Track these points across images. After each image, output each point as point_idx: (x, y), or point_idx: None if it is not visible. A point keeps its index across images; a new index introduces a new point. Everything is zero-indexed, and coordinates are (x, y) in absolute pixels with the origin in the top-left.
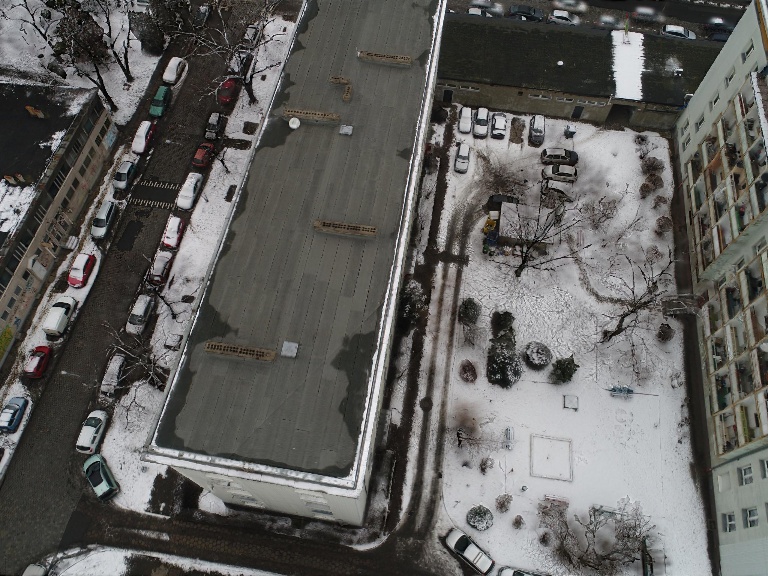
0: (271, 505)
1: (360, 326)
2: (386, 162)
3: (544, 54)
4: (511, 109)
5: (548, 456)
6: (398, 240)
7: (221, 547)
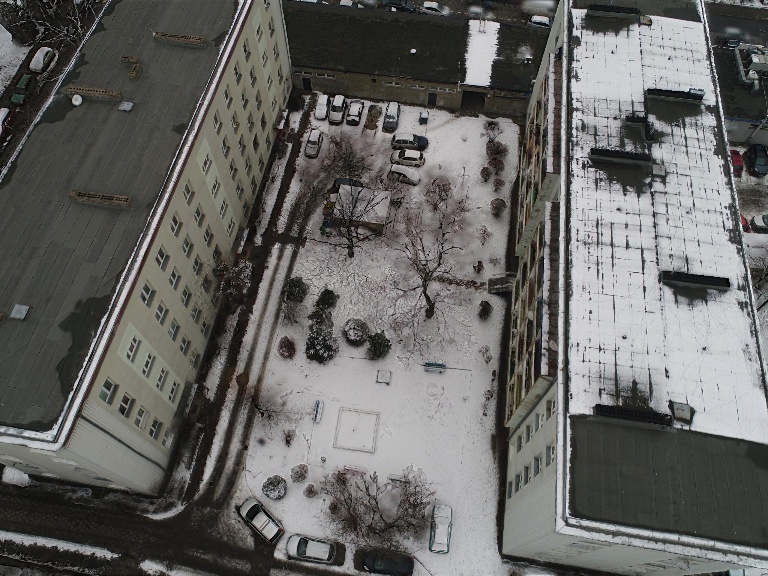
0: (58, 474)
1: (96, 290)
2: (159, 137)
3: (400, 43)
4: (369, 96)
5: (354, 428)
6: (153, 210)
7: (19, 517)
